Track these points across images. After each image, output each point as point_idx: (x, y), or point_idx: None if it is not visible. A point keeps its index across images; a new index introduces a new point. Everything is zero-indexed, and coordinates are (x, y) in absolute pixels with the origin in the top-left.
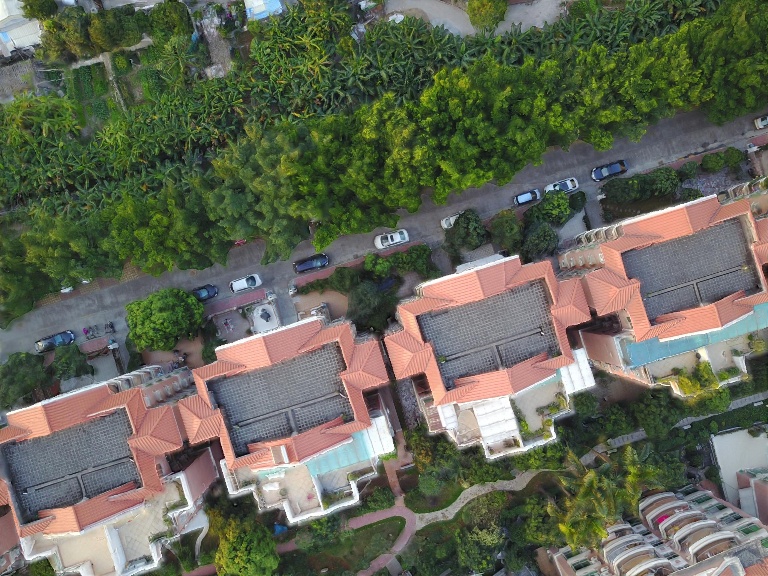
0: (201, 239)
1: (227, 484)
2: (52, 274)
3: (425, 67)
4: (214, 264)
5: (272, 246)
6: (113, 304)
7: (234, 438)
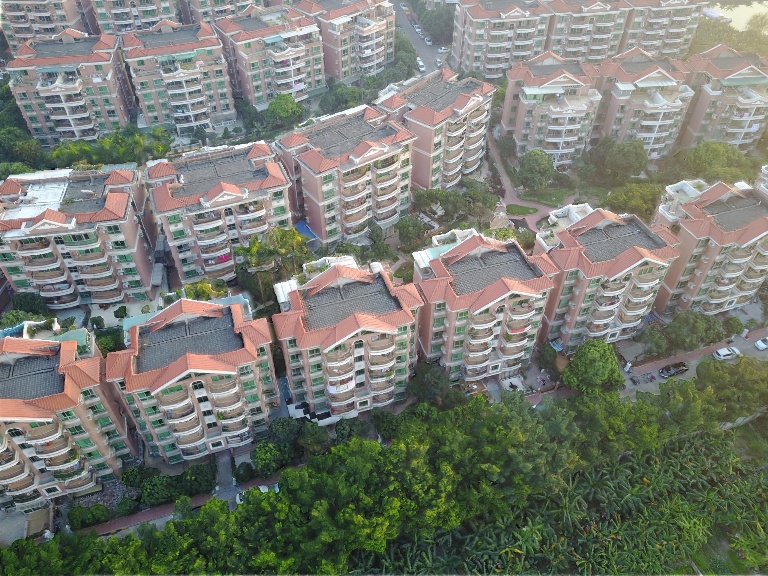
0: (578, 411)
1: None
2: (688, 382)
3: None
4: None
5: None
6: None
7: (518, 255)
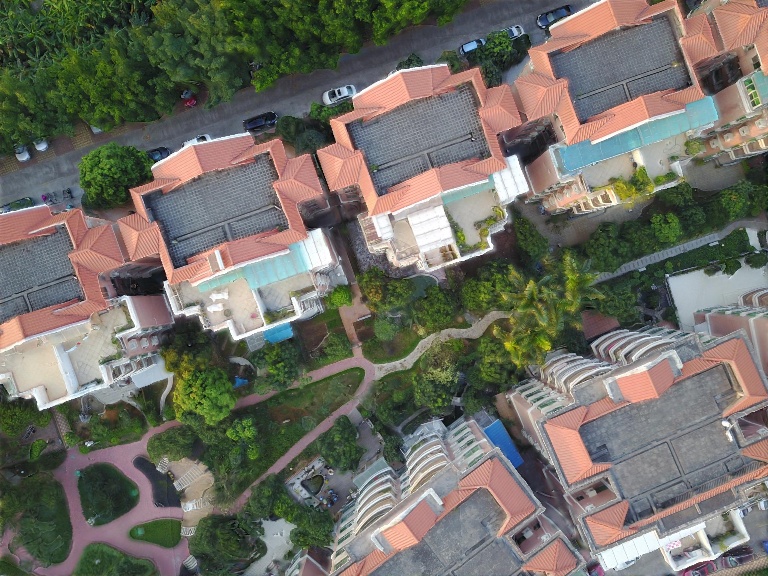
0: (145, 87)
1: (171, 304)
2: (1, 126)
3: None
4: (166, 128)
5: (214, 90)
6: (70, 171)
7: (173, 253)
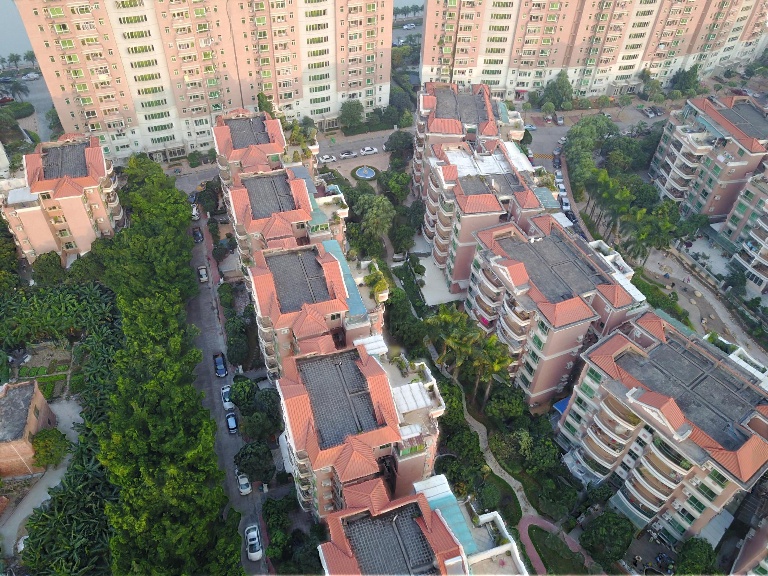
0: None
1: None
2: None
3: (86, 503)
4: None
5: None
6: None
7: None
